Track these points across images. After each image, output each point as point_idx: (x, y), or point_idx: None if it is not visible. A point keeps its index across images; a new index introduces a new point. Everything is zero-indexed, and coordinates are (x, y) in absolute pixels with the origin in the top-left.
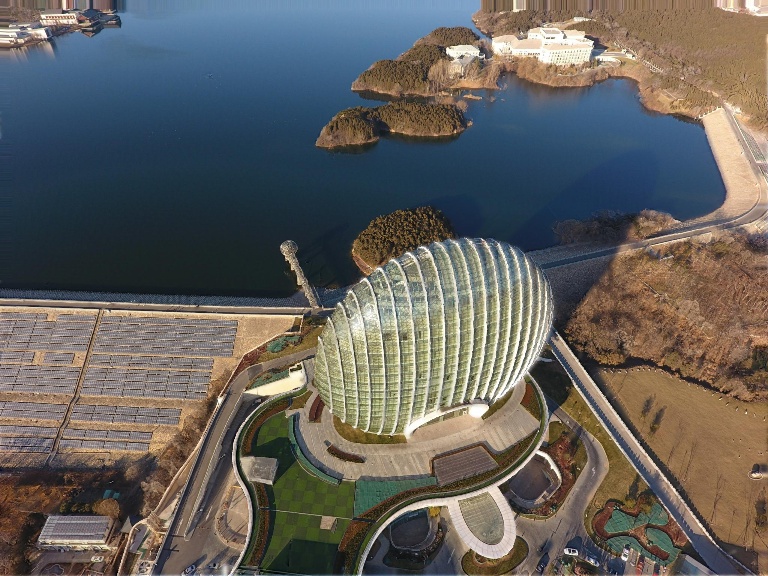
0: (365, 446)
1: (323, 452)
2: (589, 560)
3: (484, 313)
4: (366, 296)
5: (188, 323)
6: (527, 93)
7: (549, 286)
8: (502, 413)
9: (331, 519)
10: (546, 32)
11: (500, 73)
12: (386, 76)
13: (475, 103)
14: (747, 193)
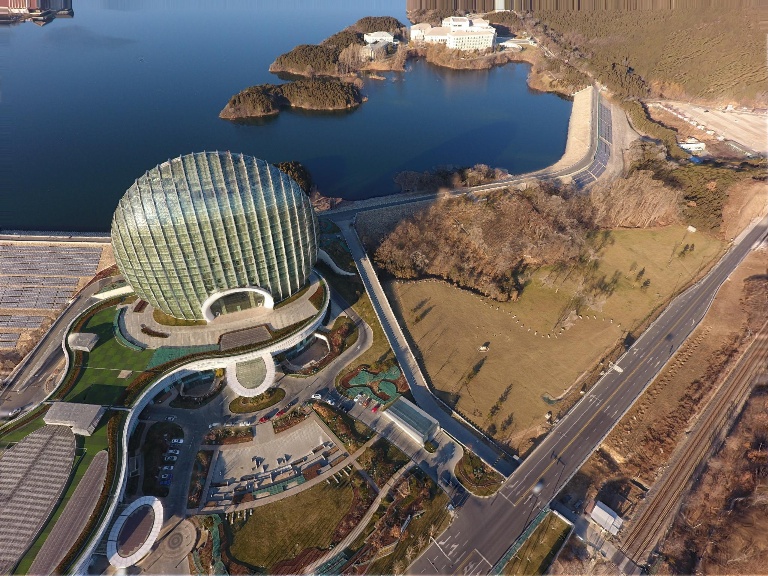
0: (172, 327)
1: (137, 331)
2: (327, 401)
3: (229, 205)
4: (134, 190)
5: (60, 250)
6: (437, 76)
7: (300, 194)
8: (291, 305)
9: (128, 372)
10: (454, 20)
11: (412, 58)
12: (300, 59)
13: (378, 83)
14: (579, 153)
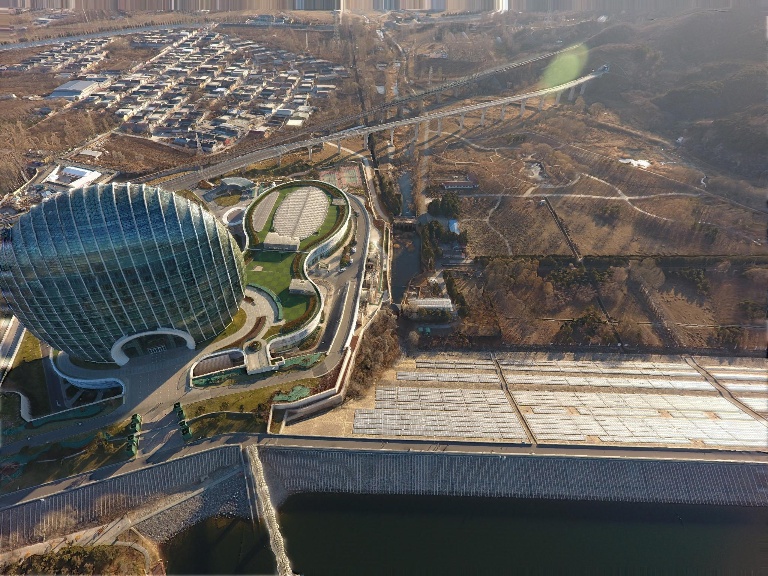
0: None
1: (257, 299)
2: None
3: None
4: None
5: (415, 432)
6: None
7: None
8: None
9: (256, 270)
10: None
11: None
12: None
13: None
14: None
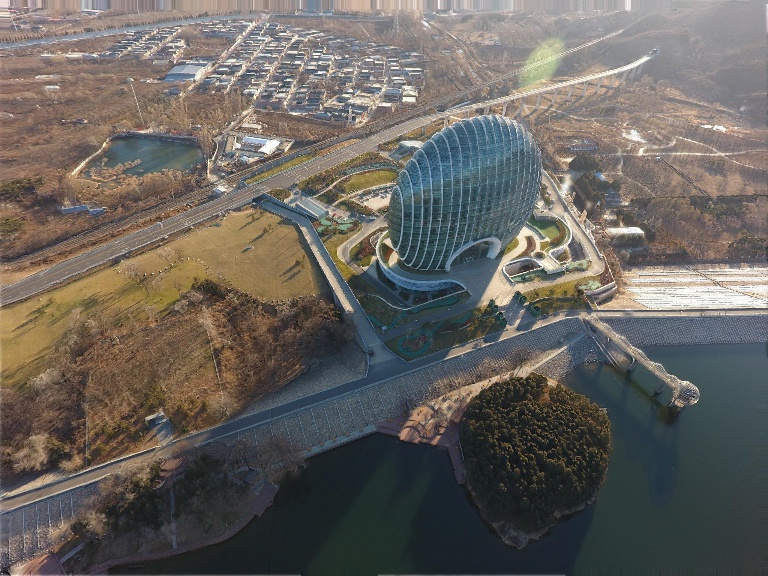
0: None
1: None
2: None
3: None
4: None
5: None
6: None
7: None
8: None
9: None
10: None
11: None
12: None
13: None
14: None
